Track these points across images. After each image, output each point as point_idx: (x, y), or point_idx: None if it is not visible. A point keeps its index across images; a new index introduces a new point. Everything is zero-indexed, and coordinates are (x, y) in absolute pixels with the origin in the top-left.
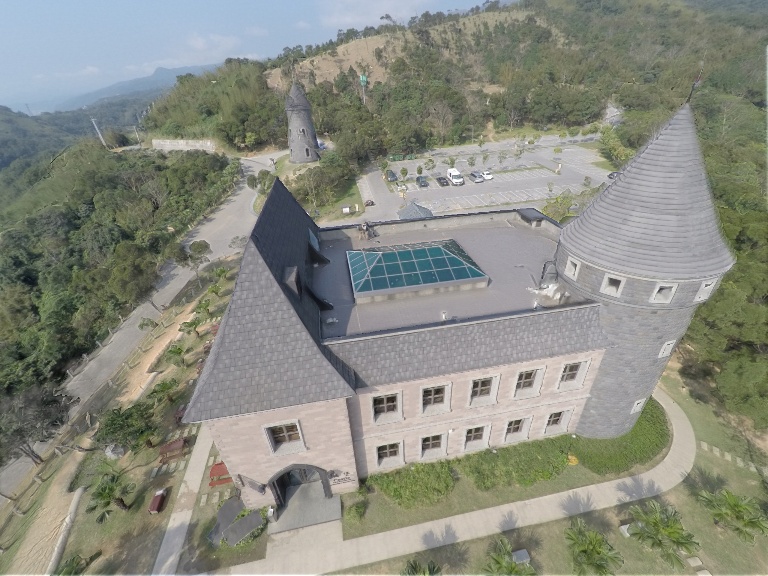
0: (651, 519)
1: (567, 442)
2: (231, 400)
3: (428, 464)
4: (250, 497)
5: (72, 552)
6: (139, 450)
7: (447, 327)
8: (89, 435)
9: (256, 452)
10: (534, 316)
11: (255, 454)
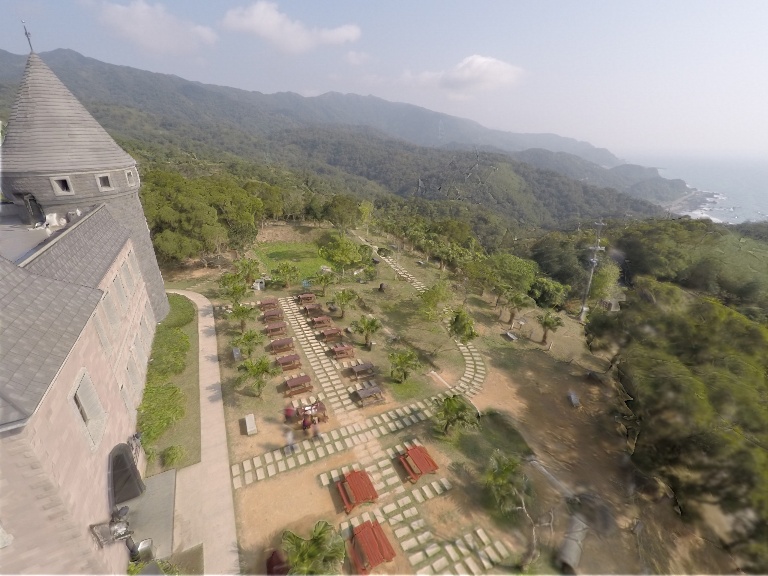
0: (231, 290)
1: (163, 326)
2: (33, 357)
3: (143, 400)
4: (113, 568)
5: None
6: None
7: (67, 233)
8: None
9: (83, 459)
10: (91, 217)
11: (83, 465)
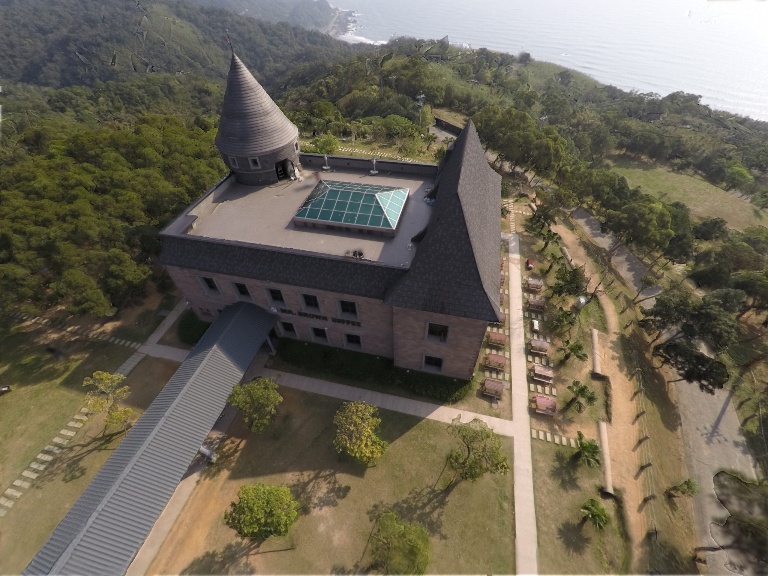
0: None
1: None
2: None
3: None
4: None
5: (567, 266)
6: (563, 301)
7: None
8: (616, 329)
9: None
10: None
11: None
